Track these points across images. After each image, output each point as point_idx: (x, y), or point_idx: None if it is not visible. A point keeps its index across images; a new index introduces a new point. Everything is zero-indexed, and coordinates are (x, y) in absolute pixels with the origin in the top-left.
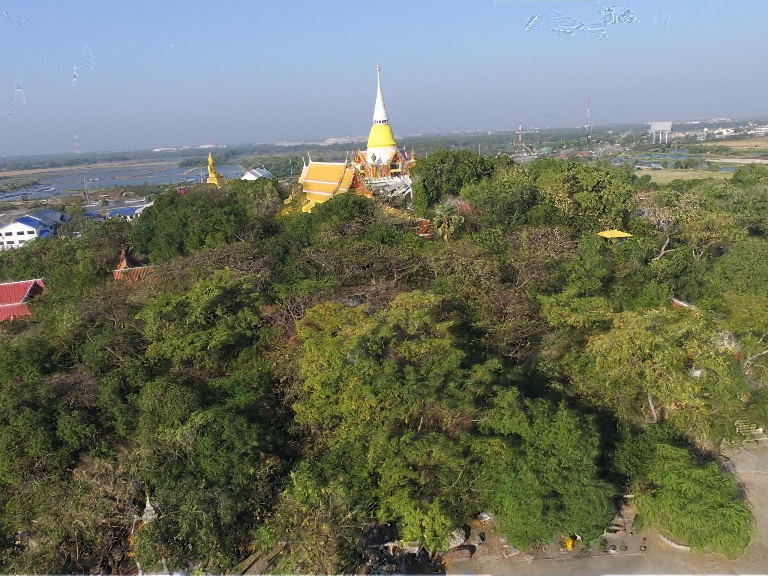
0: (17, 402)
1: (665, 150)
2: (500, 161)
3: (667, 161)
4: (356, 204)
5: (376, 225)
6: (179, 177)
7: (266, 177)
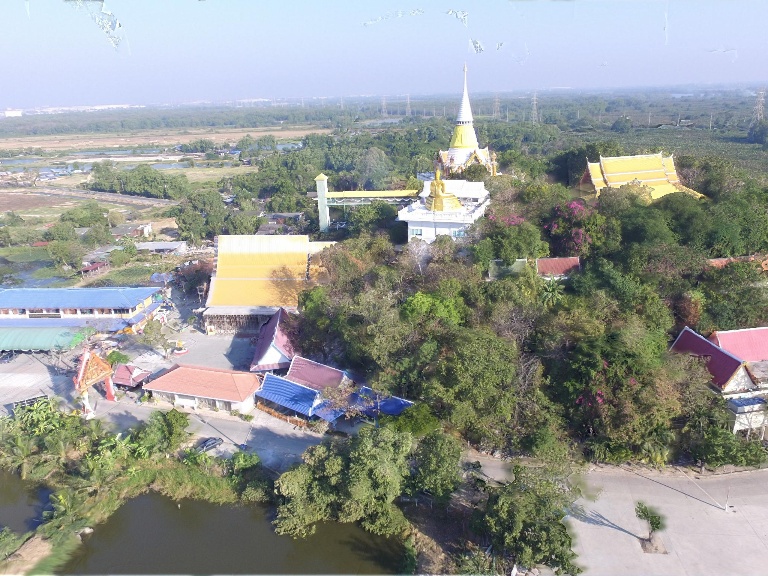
0: None
1: None
2: (585, 149)
3: (77, 164)
4: None
5: None
6: None
7: None
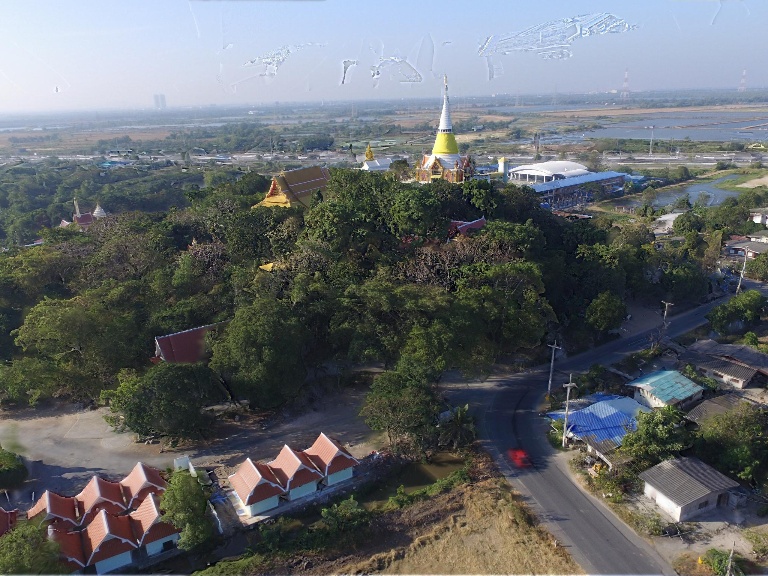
0: (6, 251)
1: None
2: None
3: None
4: (214, 203)
5: (183, 218)
6: (717, 133)
7: (387, 166)
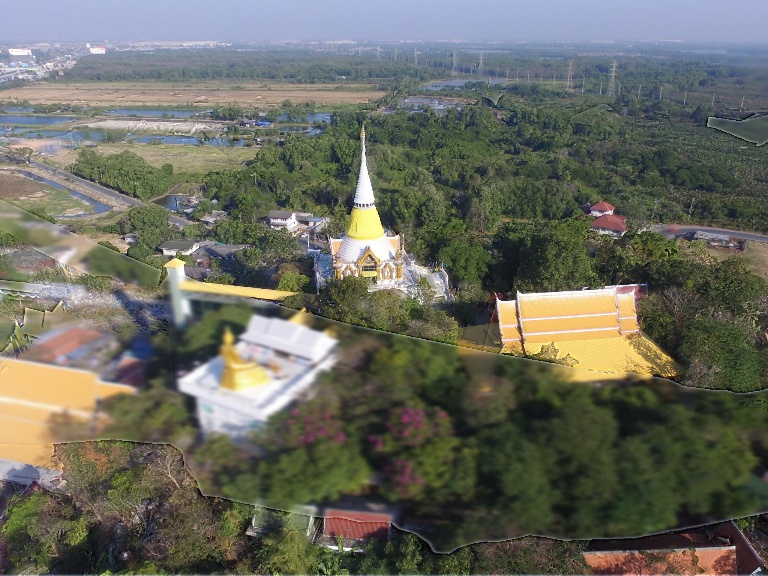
0: None
1: (0, 109)
2: None
3: None
4: None
5: None
6: None
7: None
